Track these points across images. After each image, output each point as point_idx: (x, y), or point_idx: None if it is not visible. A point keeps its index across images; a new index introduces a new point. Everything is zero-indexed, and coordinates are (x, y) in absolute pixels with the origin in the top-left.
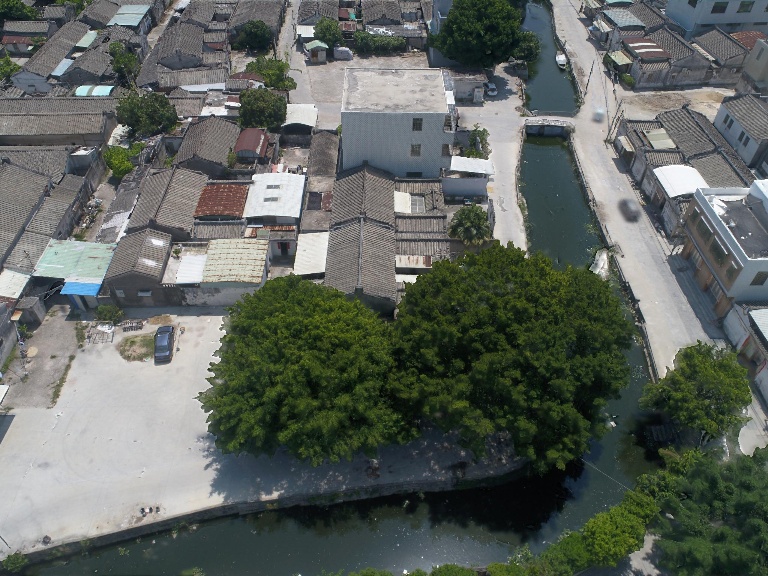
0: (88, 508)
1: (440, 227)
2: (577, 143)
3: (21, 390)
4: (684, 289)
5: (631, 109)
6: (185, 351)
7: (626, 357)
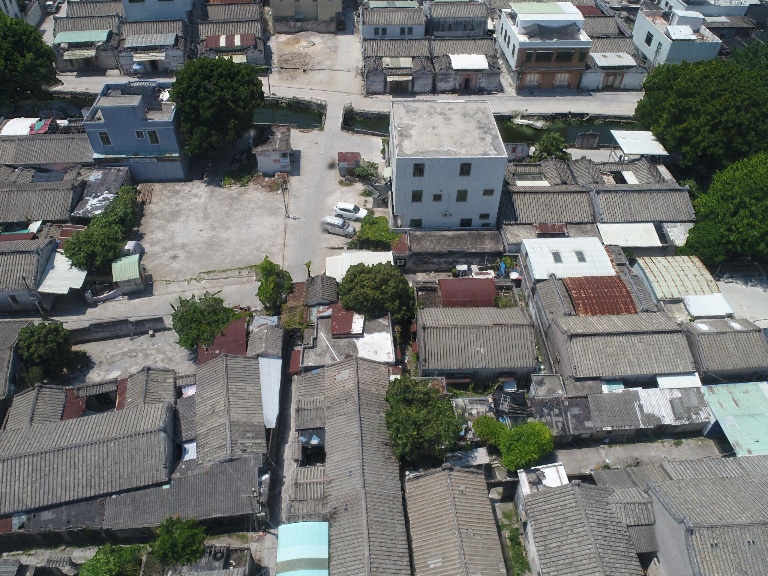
0: None
1: (562, 164)
2: (370, 109)
3: None
4: (550, 96)
5: (307, 79)
6: (766, 324)
7: (616, 127)
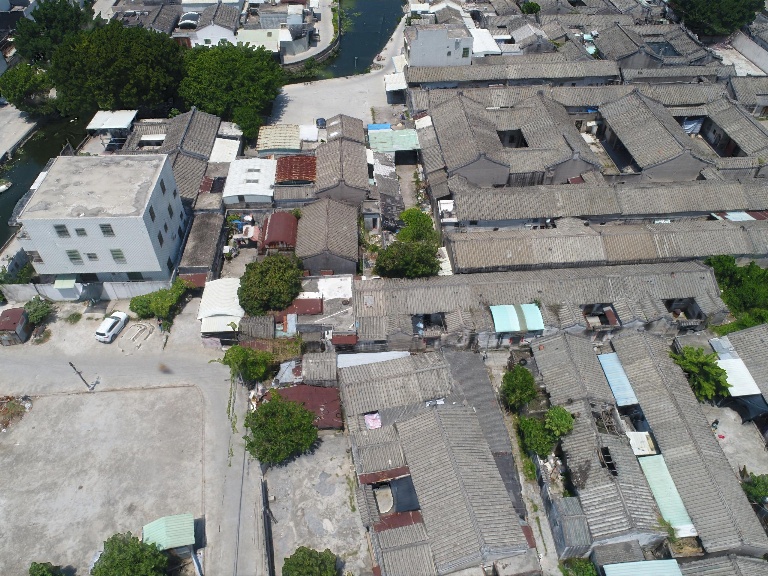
0: (335, 84)
1: None
2: None
3: (392, 111)
4: None
5: None
6: None
7: None
